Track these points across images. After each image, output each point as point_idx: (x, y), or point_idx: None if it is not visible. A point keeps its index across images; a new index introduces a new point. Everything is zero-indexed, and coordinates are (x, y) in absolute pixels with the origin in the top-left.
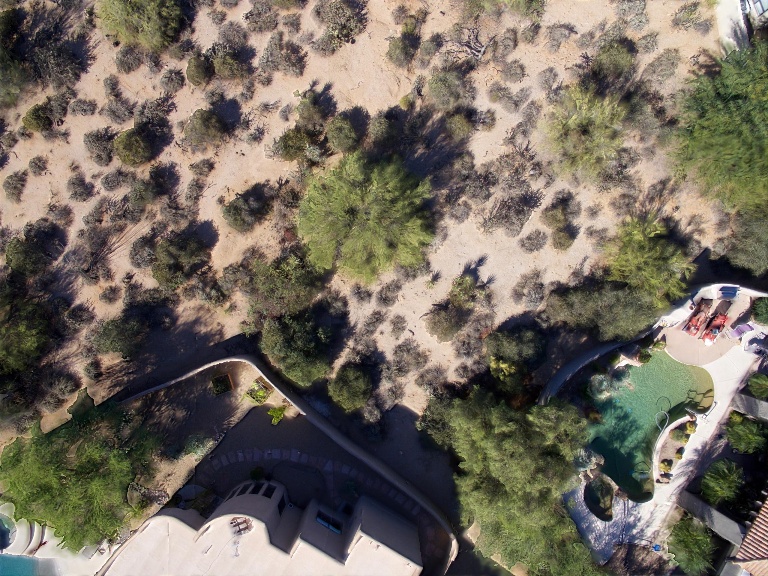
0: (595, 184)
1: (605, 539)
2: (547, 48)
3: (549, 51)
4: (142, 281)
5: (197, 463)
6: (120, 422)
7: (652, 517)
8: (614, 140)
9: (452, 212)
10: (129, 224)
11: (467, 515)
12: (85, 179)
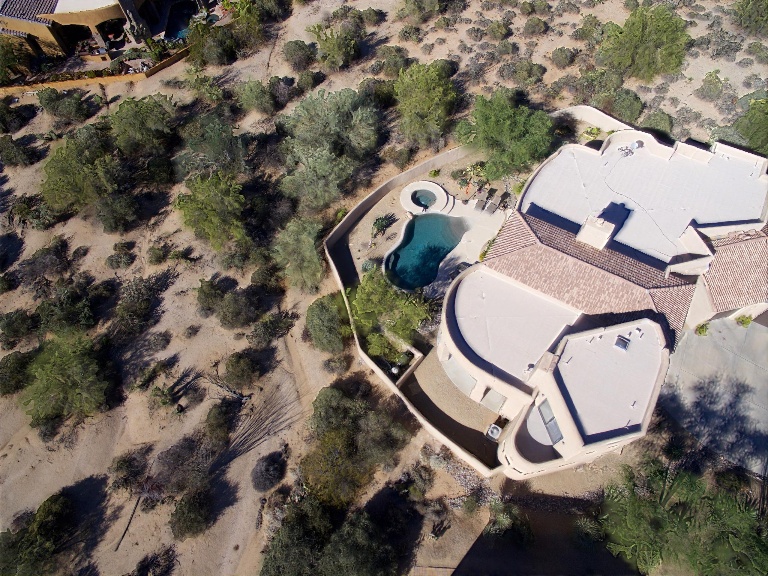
0: None
1: None
2: (714, 0)
3: (715, 1)
4: (504, 86)
5: None
6: None
7: None
8: None
9: (690, 52)
10: (493, 63)
11: None
12: None
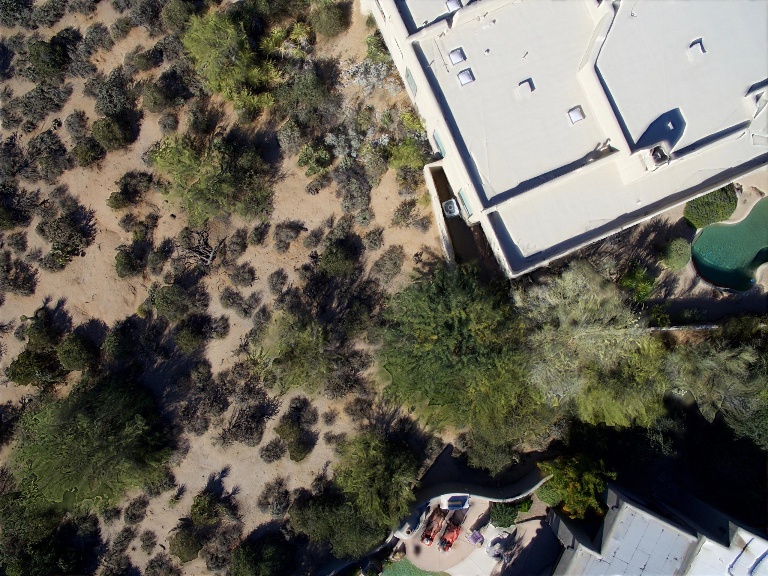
0: (324, 393)
1: None
2: (275, 250)
3: (278, 252)
4: None
5: None
6: None
7: None
8: (345, 343)
9: (189, 427)
10: None
11: None
12: None
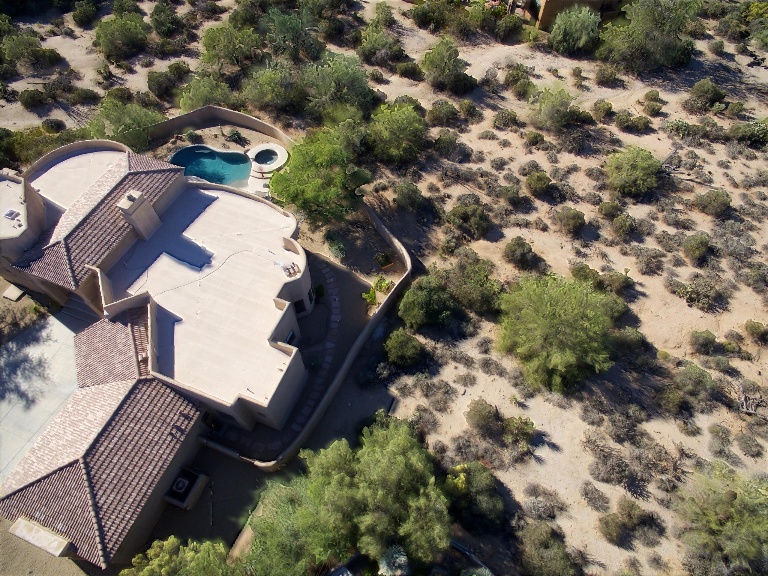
0: (689, 553)
1: None
2: None
3: None
4: (448, 204)
5: (322, 254)
6: (346, 207)
7: None
8: (749, 573)
9: (589, 406)
10: (485, 191)
11: (312, 454)
12: (506, 165)
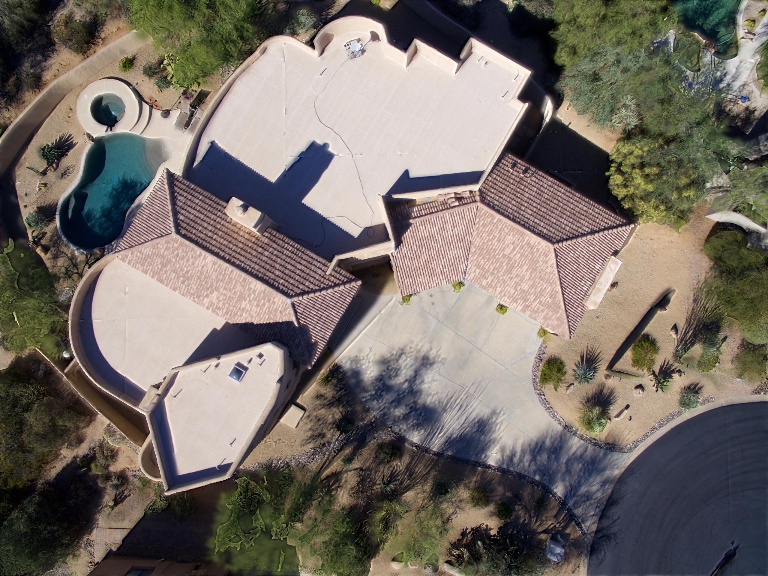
0: None
1: (694, 88)
2: None
3: None
4: None
5: None
6: None
7: (737, 72)
8: None
9: None
10: None
11: (566, 49)
12: None
